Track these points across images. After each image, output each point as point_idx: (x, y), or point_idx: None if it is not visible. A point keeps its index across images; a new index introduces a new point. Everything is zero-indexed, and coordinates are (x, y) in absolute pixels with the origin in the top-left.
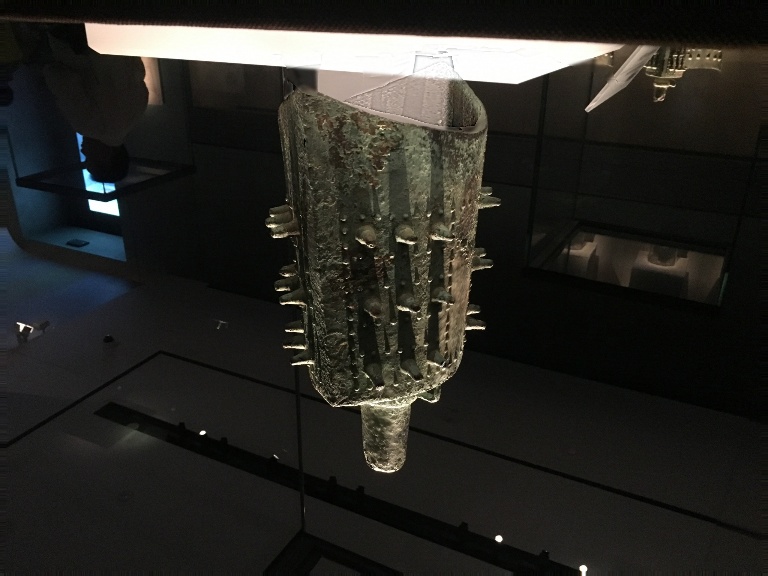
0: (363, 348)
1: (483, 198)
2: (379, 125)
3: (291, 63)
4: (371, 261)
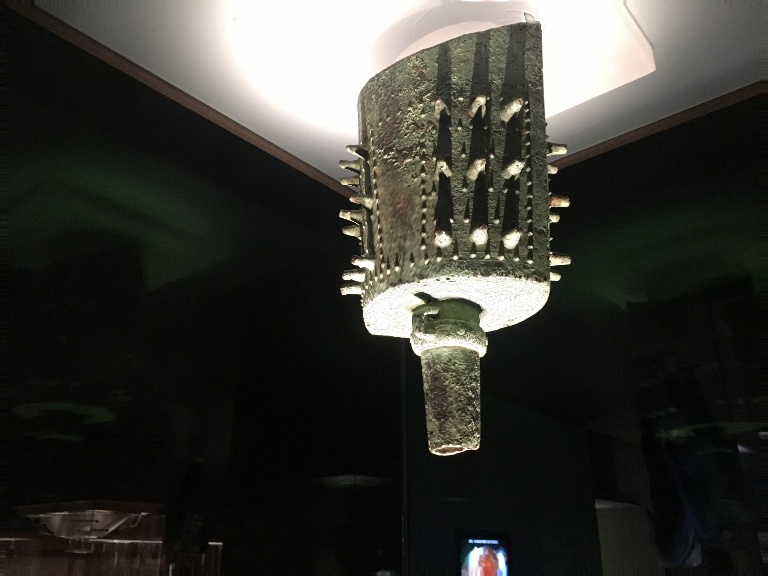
0: None
1: None
2: None
3: None
4: None
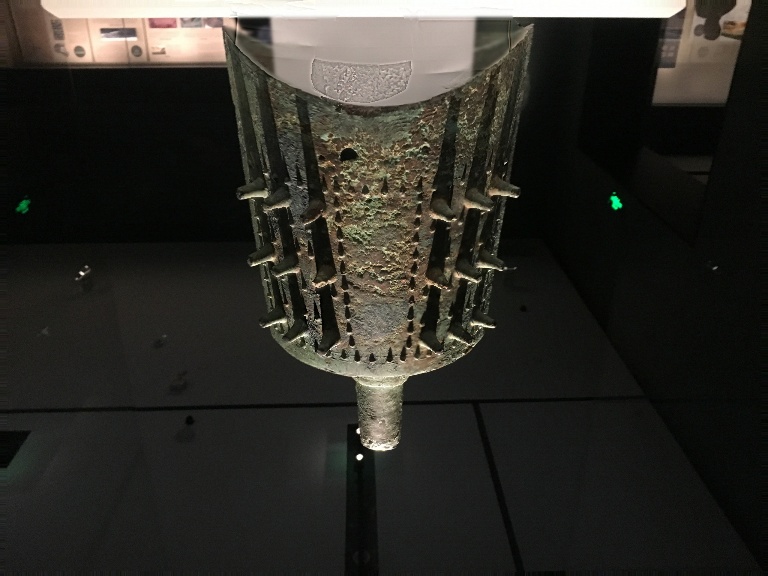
0: None
1: None
2: None
3: (482, 15)
4: None
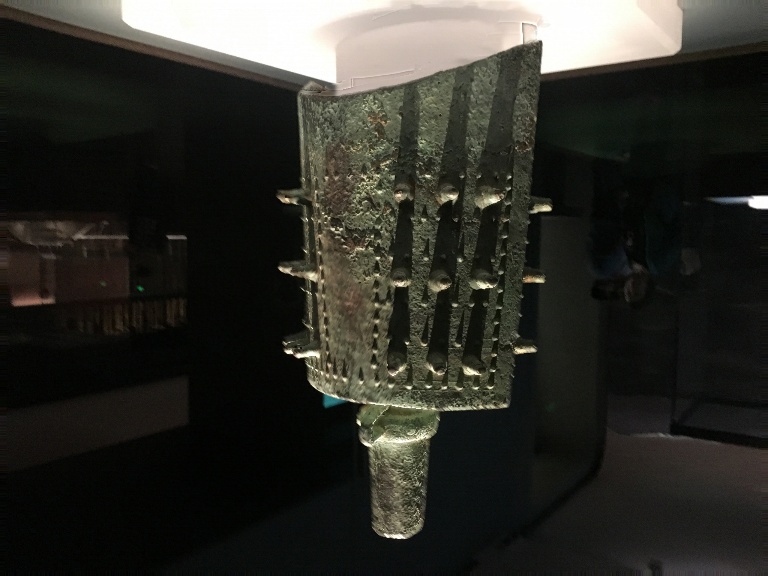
0: None
1: None
2: None
3: (376, 73)
4: None
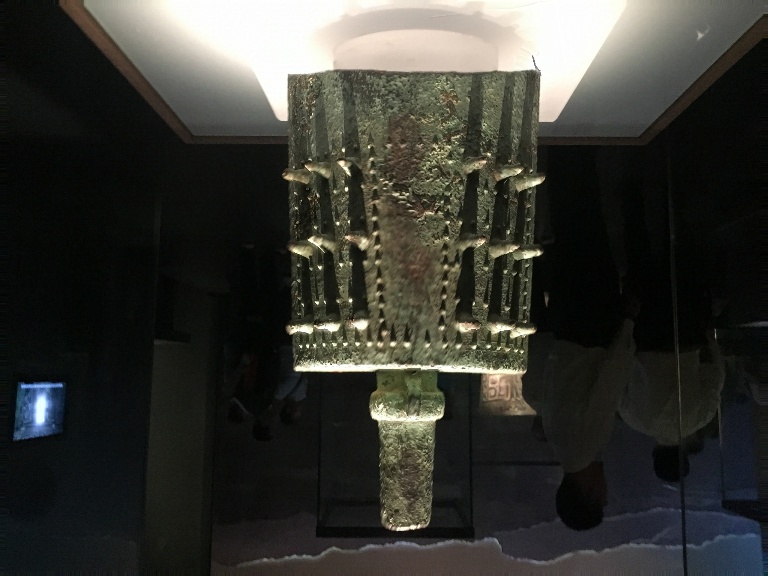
0: (304, 297)
1: (468, 158)
2: (309, 80)
3: None
4: (308, 203)
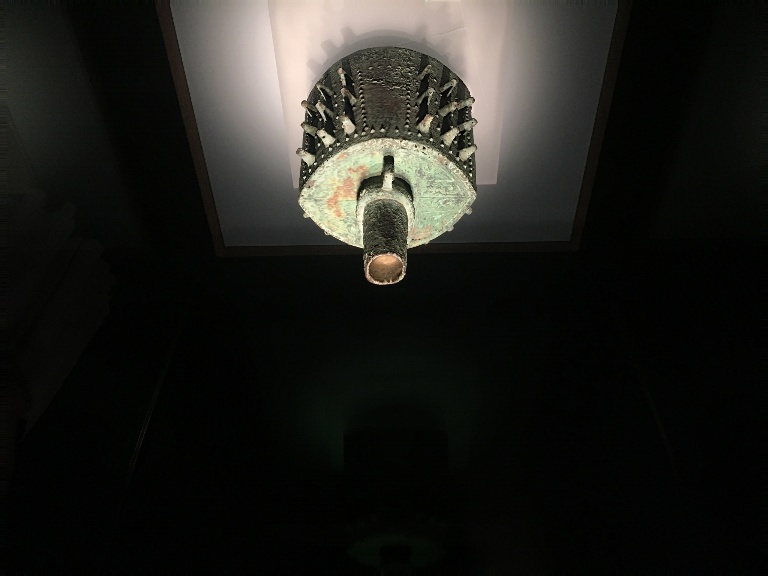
0: None
1: None
2: None
3: None
4: None
